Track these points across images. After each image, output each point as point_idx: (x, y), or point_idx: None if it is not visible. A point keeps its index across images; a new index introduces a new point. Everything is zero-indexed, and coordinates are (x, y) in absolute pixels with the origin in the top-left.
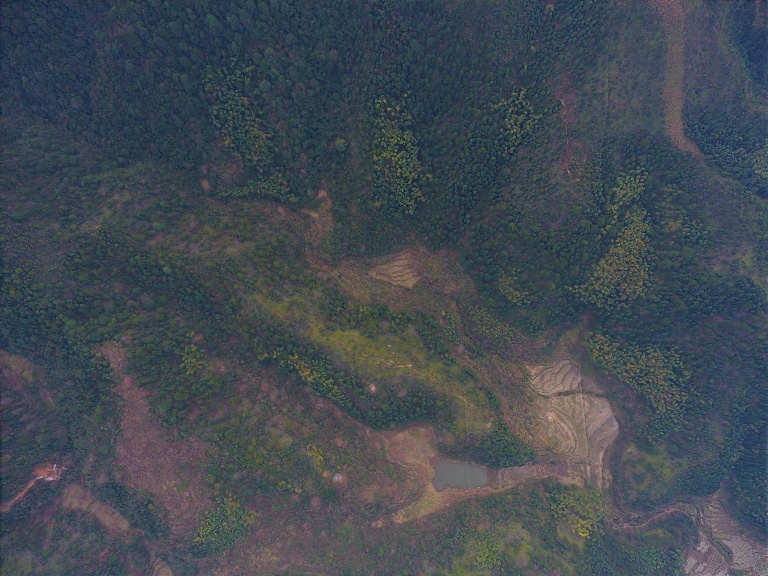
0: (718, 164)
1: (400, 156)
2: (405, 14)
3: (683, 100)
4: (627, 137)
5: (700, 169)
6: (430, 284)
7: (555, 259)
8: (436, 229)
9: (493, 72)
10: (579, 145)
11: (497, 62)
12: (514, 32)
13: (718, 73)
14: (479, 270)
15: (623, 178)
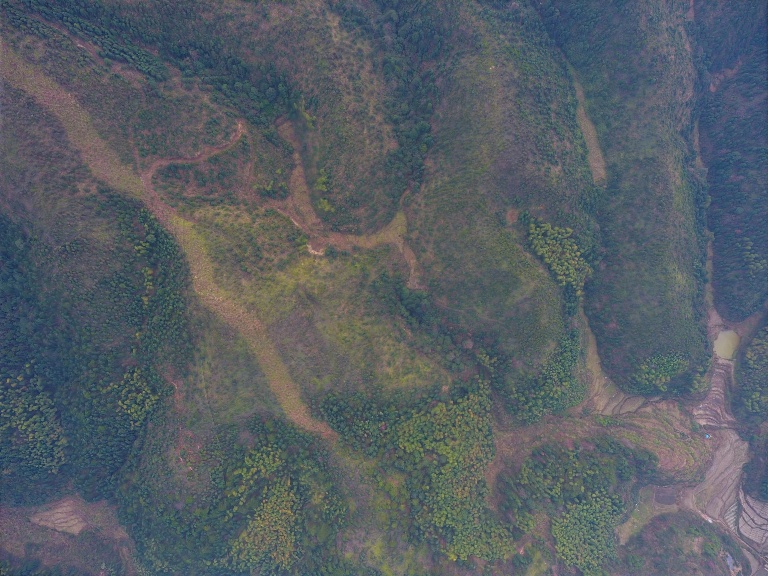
0: (351, 444)
1: (31, 422)
2: (6, 296)
3: (299, 388)
4: (248, 420)
5: (331, 450)
6: (97, 530)
7: (181, 540)
8: (85, 487)
9: (95, 359)
10: (190, 433)
11: (97, 350)
12: (107, 325)
13: (334, 361)
14: (131, 529)
15: (253, 456)
